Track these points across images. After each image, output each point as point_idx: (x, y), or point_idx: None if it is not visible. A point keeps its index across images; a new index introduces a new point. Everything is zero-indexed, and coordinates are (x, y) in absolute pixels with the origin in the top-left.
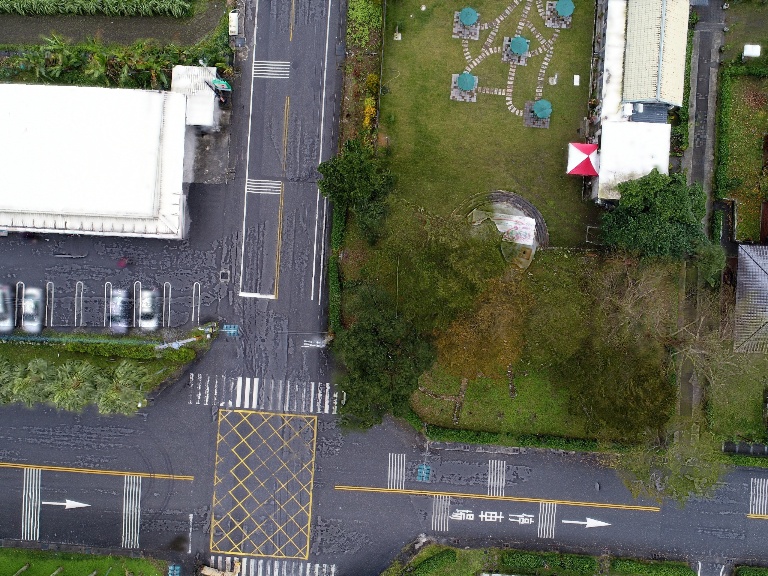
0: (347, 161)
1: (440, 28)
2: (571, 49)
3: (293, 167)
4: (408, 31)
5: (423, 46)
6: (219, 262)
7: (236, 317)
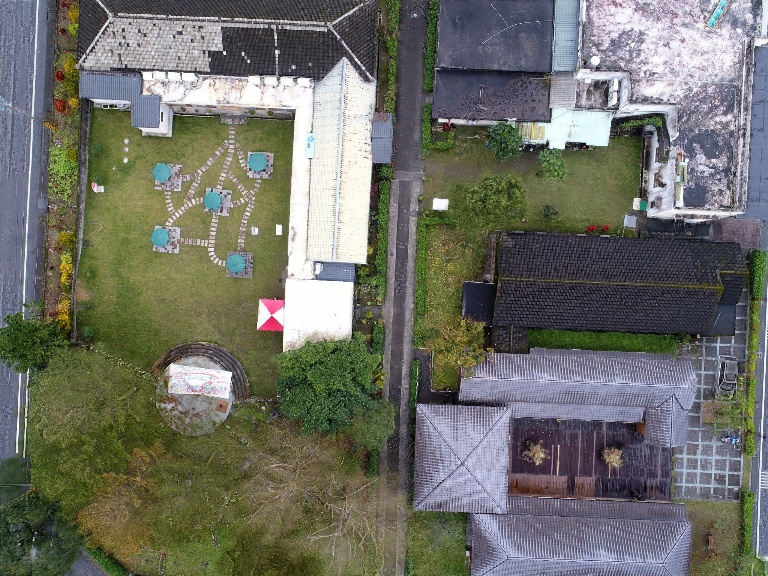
0: None
1: (142, 180)
2: (273, 199)
3: None
4: (110, 183)
5: (125, 198)
6: None
7: None
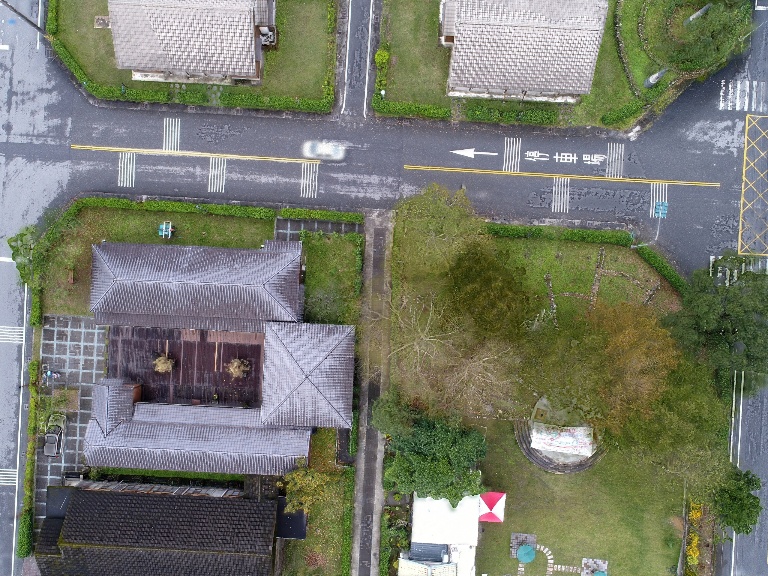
0: None
1: None
2: None
3: (763, 496)
4: None
5: None
6: None
7: None
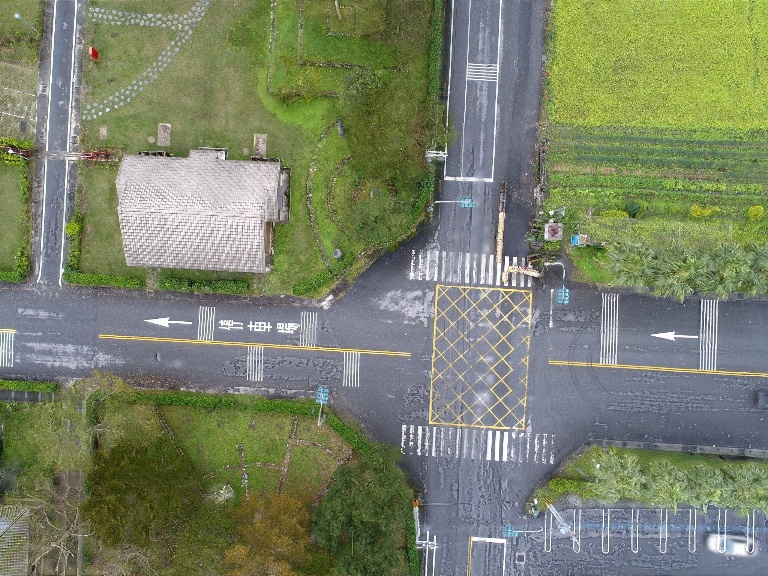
0: None
1: None
2: None
3: None
4: None
5: None
6: (526, 572)
7: (509, 519)
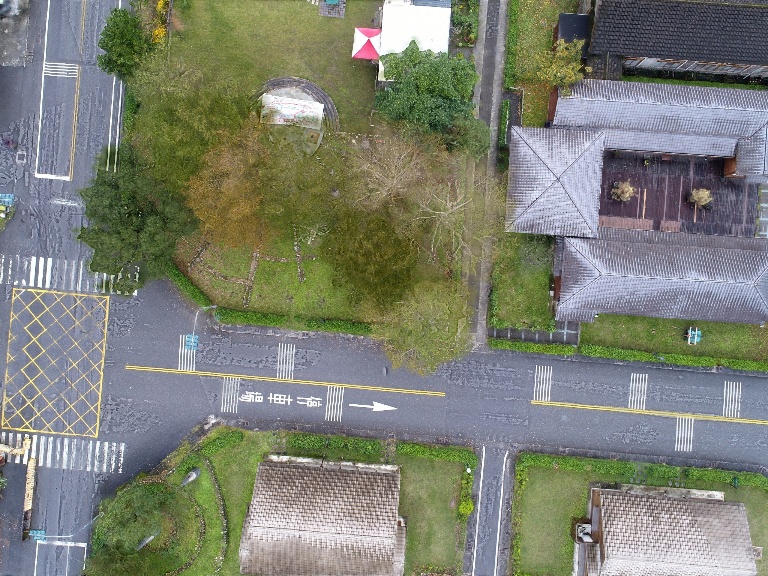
0: (107, 26)
1: None
2: None
3: (90, 51)
4: None
5: None
6: (16, 143)
7: (31, 198)
